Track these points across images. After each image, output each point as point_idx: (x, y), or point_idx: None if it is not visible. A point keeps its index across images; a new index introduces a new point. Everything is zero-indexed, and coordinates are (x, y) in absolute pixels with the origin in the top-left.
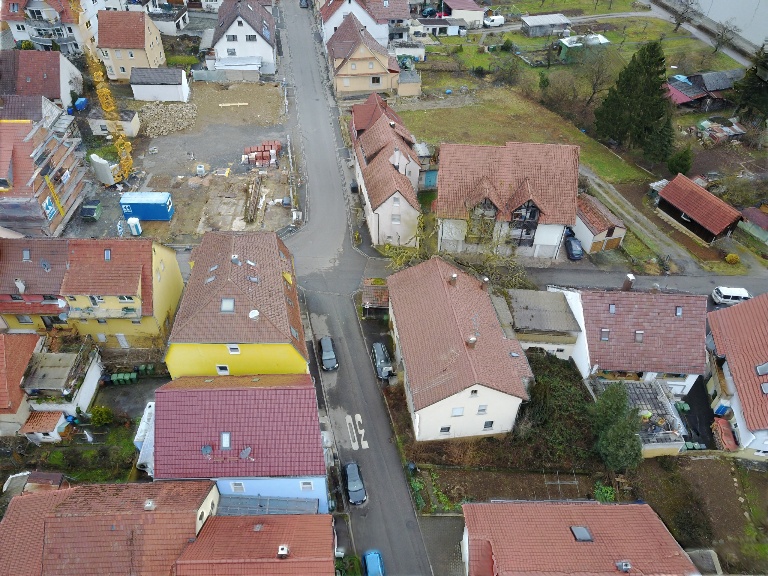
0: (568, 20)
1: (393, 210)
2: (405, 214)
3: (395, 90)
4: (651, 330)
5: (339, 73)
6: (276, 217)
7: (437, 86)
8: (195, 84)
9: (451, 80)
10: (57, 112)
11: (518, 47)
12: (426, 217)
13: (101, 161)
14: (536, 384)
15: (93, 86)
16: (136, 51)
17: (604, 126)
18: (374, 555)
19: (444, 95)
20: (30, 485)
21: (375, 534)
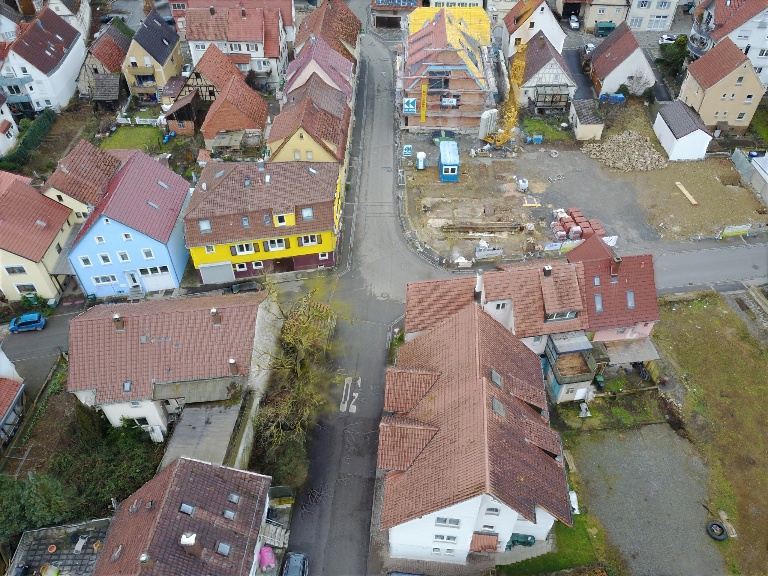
0: None
1: None
2: None
3: None
4: (113, 567)
5: None
6: (458, 248)
7: None
8: (722, 160)
9: None
10: (565, 81)
11: None
12: None
13: (485, 115)
14: (87, 404)
15: (652, 96)
16: (700, 89)
17: None
18: (34, 317)
19: None
20: (157, 160)
21: (61, 327)
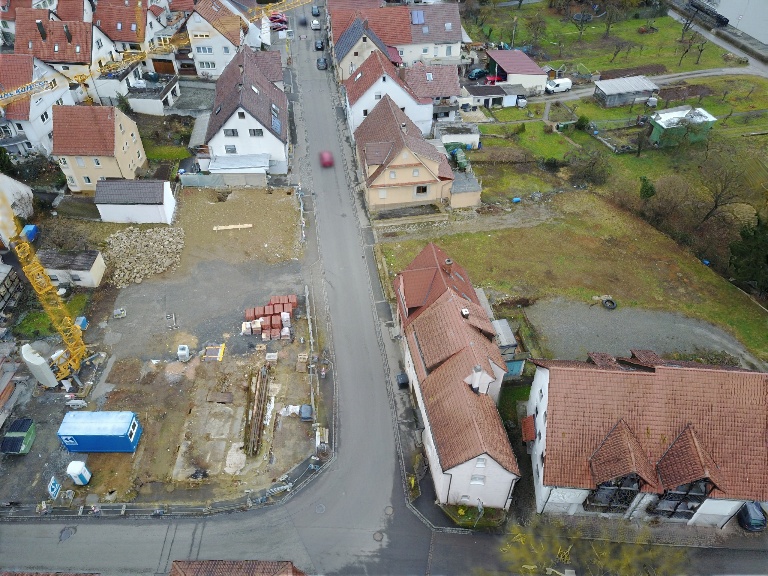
0: (654, 85)
1: (475, 471)
2: (493, 476)
3: (446, 200)
4: None
5: (373, 184)
6: (291, 441)
7: (499, 188)
8: (183, 192)
9: (515, 177)
10: None
11: (595, 125)
12: (512, 438)
13: (35, 360)
14: None
15: (47, 204)
16: (103, 158)
17: (749, 271)
18: None
19: (511, 205)
20: None
21: None
